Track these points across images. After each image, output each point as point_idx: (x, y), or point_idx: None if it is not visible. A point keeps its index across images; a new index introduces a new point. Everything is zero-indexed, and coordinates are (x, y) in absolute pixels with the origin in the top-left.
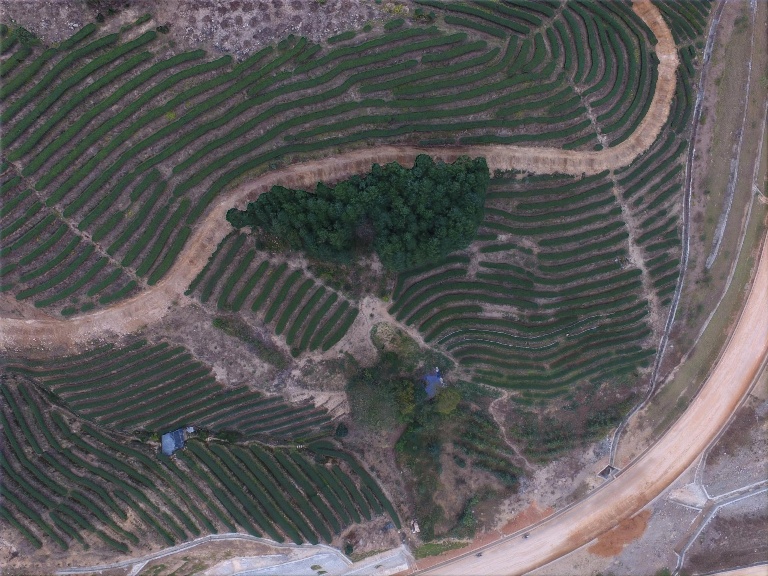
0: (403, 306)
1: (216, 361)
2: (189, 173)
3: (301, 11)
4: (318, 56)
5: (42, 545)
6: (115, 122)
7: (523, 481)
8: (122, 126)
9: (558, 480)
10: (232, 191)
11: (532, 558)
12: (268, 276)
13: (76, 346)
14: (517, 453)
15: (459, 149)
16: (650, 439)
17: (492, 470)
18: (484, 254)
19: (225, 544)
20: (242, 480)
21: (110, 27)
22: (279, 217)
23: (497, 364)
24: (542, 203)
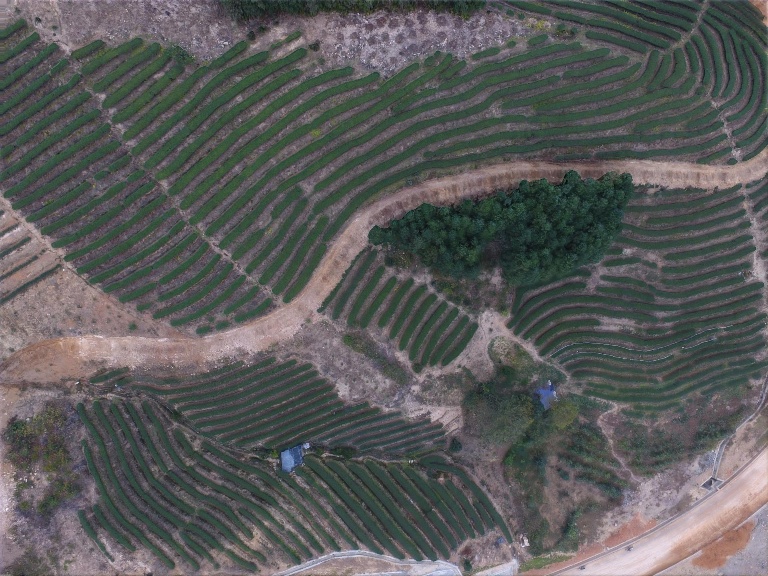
0: (520, 320)
1: (340, 377)
2: (329, 190)
3: (446, 27)
4: (462, 72)
5: (175, 565)
6: (263, 140)
7: (627, 493)
8: (268, 144)
9: (663, 492)
10: (367, 207)
11: (635, 571)
12: (394, 292)
13: (206, 364)
14: (623, 466)
15: (593, 164)
16: (753, 450)
17: (596, 483)
18: (606, 268)
19: (348, 561)
20: (360, 496)
21: (259, 45)
22: (425, 234)
23: (610, 377)
24: (672, 217)
